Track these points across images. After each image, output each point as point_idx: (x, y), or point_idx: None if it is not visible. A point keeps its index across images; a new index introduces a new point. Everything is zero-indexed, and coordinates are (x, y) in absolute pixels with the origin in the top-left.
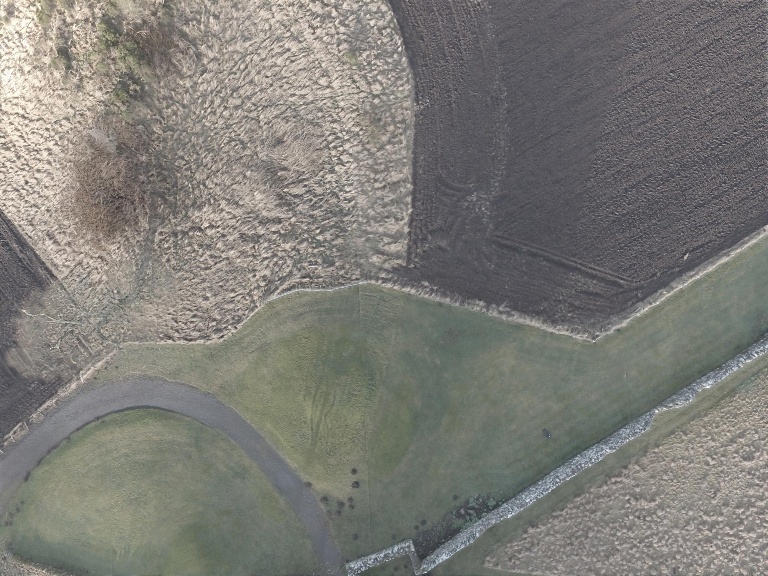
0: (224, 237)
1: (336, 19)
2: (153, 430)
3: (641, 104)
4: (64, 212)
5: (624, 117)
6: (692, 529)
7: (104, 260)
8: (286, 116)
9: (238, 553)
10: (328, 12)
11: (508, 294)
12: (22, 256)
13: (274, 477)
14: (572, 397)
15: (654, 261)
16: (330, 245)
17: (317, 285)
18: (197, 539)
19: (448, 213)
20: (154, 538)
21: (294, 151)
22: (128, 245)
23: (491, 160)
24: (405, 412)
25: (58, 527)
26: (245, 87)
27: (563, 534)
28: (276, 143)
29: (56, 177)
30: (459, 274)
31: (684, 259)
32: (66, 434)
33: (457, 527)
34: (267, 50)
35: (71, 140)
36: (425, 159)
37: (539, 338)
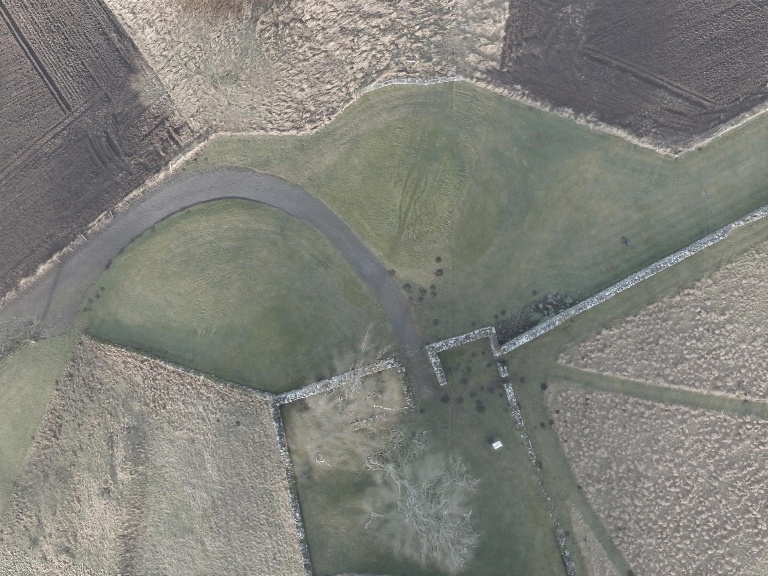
0: (324, 30)
1: None
2: (240, 218)
3: None
4: None
5: None
6: (759, 345)
7: (203, 50)
8: None
9: (319, 334)
10: None
11: (596, 105)
12: (120, 46)
13: (358, 265)
14: (652, 208)
15: (738, 86)
16: (428, 42)
17: (413, 79)
18: (280, 318)
19: (543, 22)
20: (237, 317)
21: None
22: (229, 34)
23: None
24: (492, 205)
25: (139, 310)
26: None
27: (635, 339)
28: None
29: None
30: (550, 82)
31: (767, 86)
32: (151, 224)
33: (535, 320)
34: None
35: None
36: None
37: (623, 150)
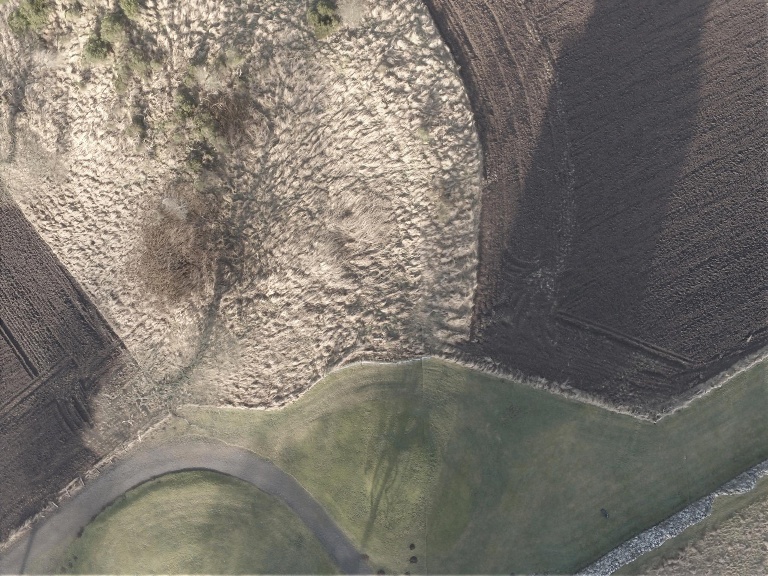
0: (289, 306)
1: (409, 94)
2: (210, 493)
3: (708, 184)
4: (129, 274)
5: (691, 197)
6: None
7: (167, 322)
8: (355, 188)
9: None
10: (401, 86)
11: (570, 372)
12: (84, 313)
13: (331, 547)
14: (631, 477)
15: (717, 343)
16: (395, 318)
17: (381, 358)
18: None
19: (513, 289)
20: None
21: (362, 223)
22: (192, 309)
23: (557, 237)
24: (465, 489)
25: None
26: (316, 158)
27: None
28: (344, 214)
29: (123, 239)
30: (522, 350)
31: (747, 341)
32: (122, 491)
33: None
34: (339, 123)
35: (140, 205)
36: (491, 234)
37: (600, 417)
